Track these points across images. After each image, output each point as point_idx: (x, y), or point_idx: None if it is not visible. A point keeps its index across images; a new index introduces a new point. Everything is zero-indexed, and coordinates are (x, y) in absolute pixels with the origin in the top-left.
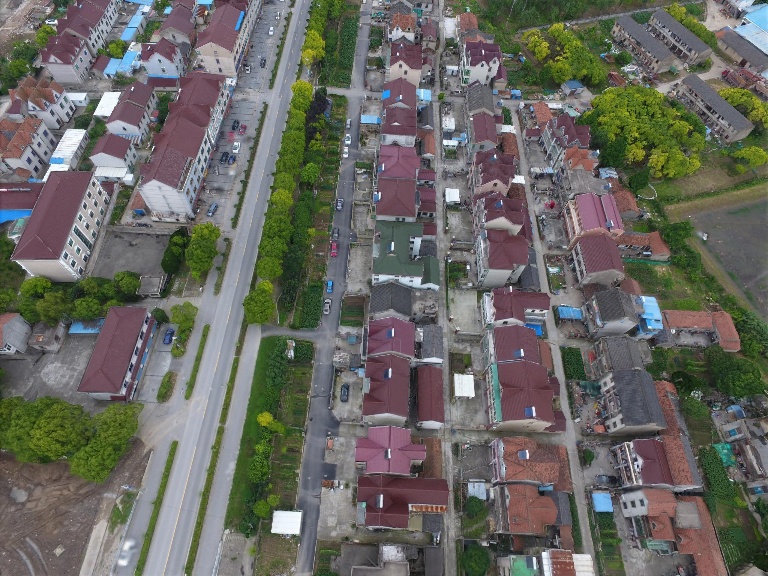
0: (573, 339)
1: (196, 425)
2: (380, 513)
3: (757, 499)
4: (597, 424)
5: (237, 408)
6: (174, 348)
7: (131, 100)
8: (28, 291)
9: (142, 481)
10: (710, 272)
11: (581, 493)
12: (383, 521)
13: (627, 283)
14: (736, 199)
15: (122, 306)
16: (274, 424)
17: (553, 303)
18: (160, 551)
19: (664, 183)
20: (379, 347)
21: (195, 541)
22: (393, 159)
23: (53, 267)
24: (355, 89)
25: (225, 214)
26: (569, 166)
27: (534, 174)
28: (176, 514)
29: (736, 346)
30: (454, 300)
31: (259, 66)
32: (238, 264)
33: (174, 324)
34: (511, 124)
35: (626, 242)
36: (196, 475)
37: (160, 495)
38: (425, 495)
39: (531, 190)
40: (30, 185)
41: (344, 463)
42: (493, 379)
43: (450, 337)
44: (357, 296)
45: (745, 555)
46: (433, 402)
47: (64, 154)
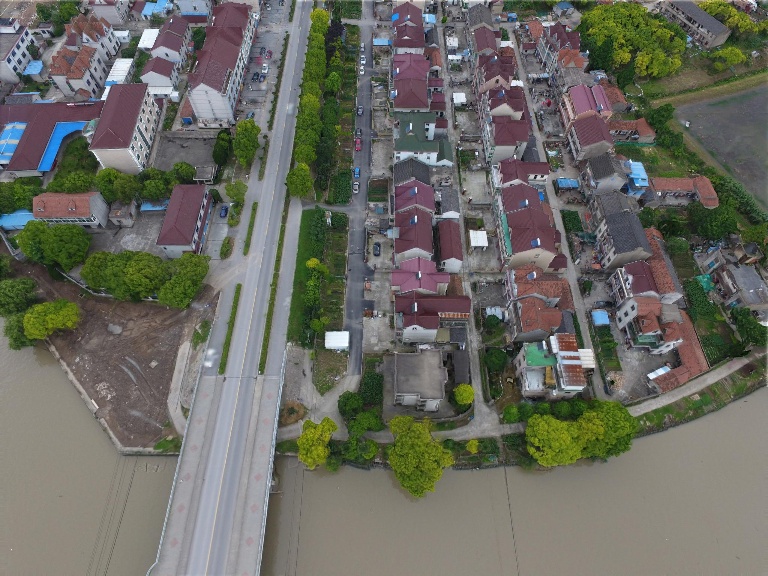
0: (571, 204)
1: (255, 273)
2: (415, 315)
3: (732, 308)
4: (594, 264)
5: (288, 260)
6: (230, 219)
7: (171, 30)
8: (103, 178)
9: (216, 312)
10: (692, 150)
11: (582, 314)
12: (418, 322)
13: (617, 158)
14: (715, 93)
15: (184, 185)
16: (321, 265)
17: (553, 178)
18: (237, 357)
19: (649, 83)
20: (405, 203)
21: (264, 349)
22: (406, 63)
23: (123, 158)
24: (366, 20)
25: (261, 120)
26: (562, 65)
27: (531, 79)
28: (246, 333)
29: (715, 203)
30: (466, 179)
31: (278, 4)
32: (277, 157)
33: (227, 203)
34: (509, 41)
35: (616, 127)
36: (259, 307)
37: (232, 320)
38: (451, 304)
39: (529, 93)
40: (92, 102)
41: (381, 299)
42: (503, 225)
43: (464, 206)
44: (381, 179)
45: (723, 353)
46: (453, 245)
47: (117, 78)
